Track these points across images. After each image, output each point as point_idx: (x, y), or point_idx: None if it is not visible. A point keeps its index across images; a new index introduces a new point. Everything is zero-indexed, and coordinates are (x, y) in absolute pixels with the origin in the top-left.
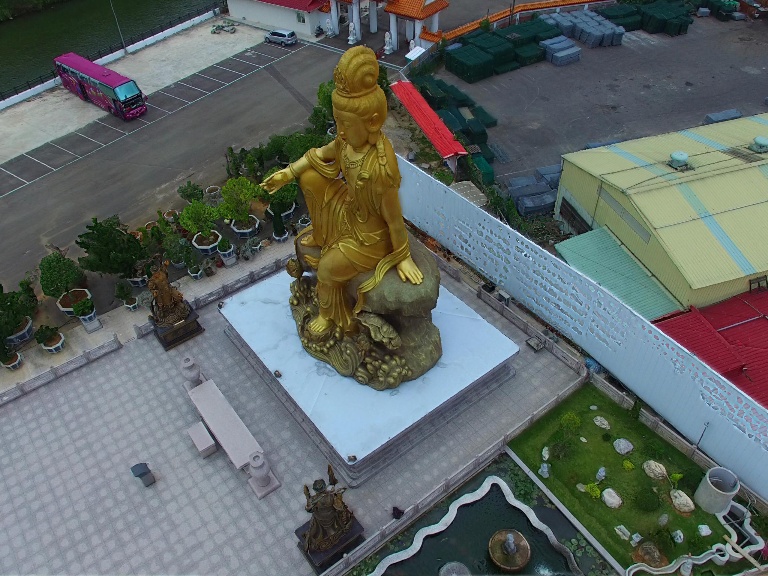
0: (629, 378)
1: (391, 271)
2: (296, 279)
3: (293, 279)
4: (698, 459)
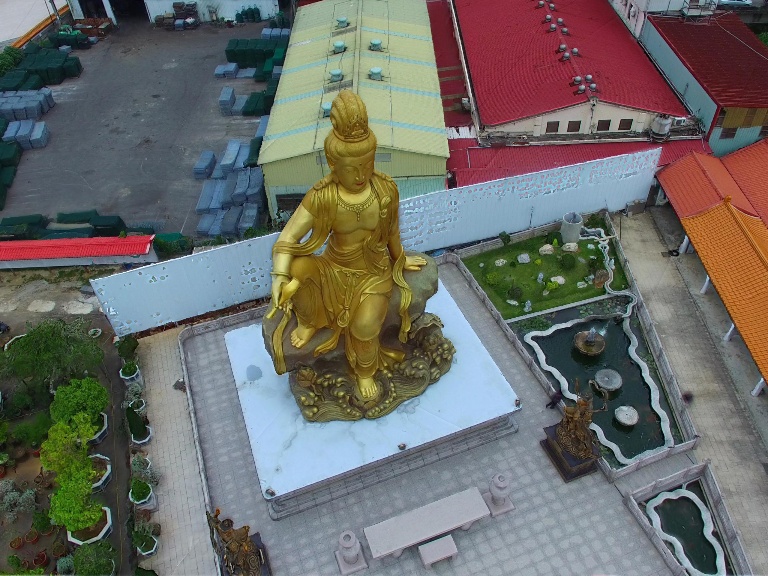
0: (470, 235)
1: (404, 275)
2: (296, 394)
3: (264, 415)
4: (537, 233)
